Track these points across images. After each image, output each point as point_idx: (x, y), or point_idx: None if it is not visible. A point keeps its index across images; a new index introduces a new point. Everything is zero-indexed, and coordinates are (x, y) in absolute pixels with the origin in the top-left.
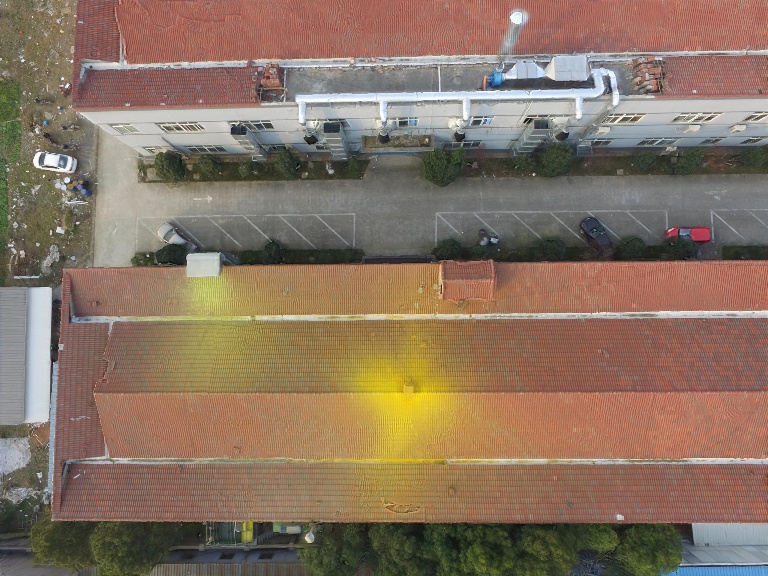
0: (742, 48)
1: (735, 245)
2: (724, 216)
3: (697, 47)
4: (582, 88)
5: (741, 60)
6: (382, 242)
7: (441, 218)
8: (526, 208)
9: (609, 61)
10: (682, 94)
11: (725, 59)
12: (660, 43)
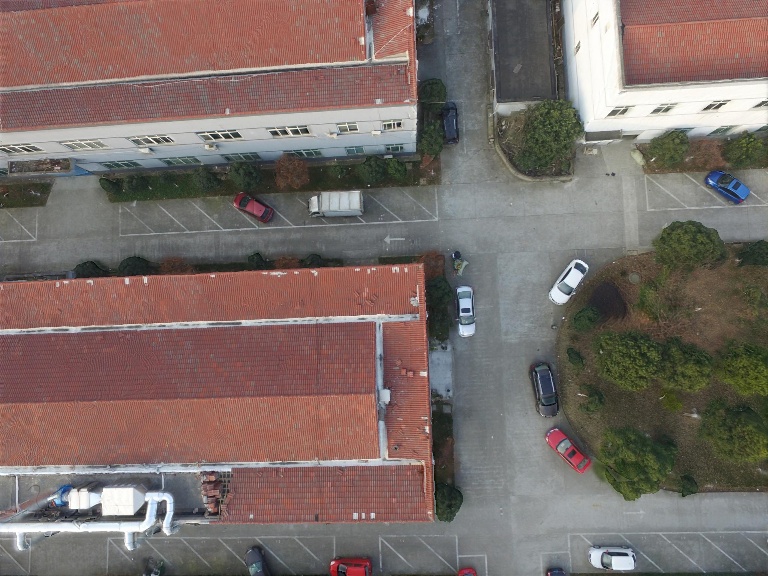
0: (311, 459)
1: (404, 574)
2: (392, 543)
3: (265, 459)
4: (131, 521)
5: (308, 474)
6: (56, 568)
7: (112, 544)
8: (195, 534)
9: (180, 472)
10: (238, 521)
11: (293, 472)
12: (227, 456)
